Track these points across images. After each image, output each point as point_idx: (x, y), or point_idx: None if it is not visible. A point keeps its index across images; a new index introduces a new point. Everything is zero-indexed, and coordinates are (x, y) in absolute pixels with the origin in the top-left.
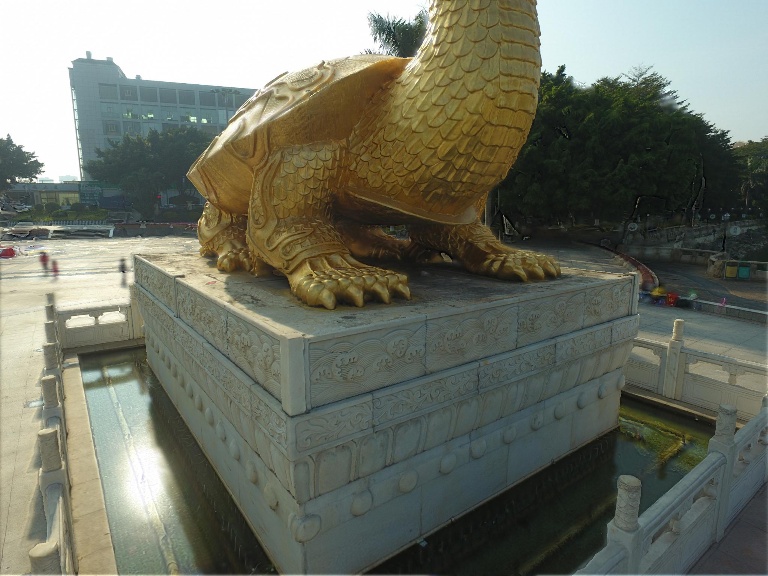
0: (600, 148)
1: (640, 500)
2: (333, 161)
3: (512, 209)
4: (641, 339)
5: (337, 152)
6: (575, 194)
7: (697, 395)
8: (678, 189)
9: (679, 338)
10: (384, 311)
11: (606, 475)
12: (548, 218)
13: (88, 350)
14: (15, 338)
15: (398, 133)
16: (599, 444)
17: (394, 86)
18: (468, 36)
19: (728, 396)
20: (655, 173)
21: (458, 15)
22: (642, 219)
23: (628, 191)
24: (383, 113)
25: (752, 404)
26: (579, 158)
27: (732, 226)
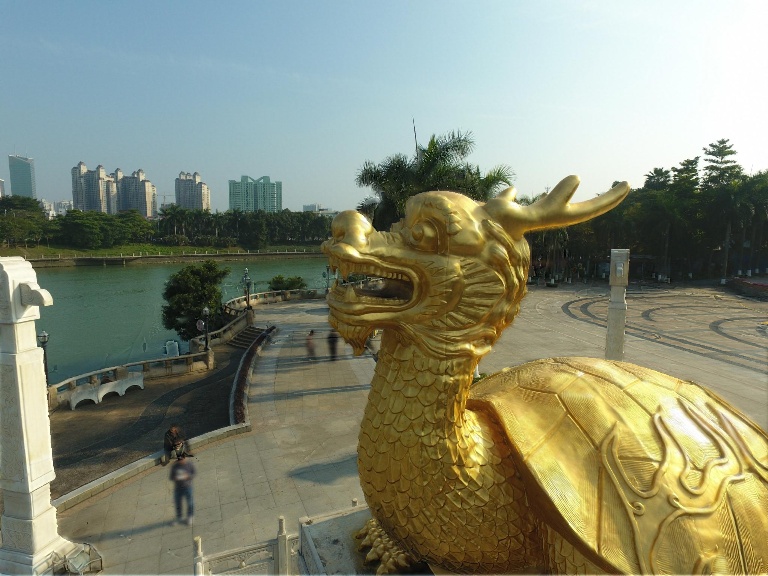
0: None
1: None
2: None
3: None
4: None
5: None
6: None
7: None
8: None
9: None
10: (344, 559)
11: None
12: None
13: None
14: None
15: None
16: None
17: None
18: None
19: None
20: None
21: None
22: None
23: None
24: None
25: None
26: None
27: None
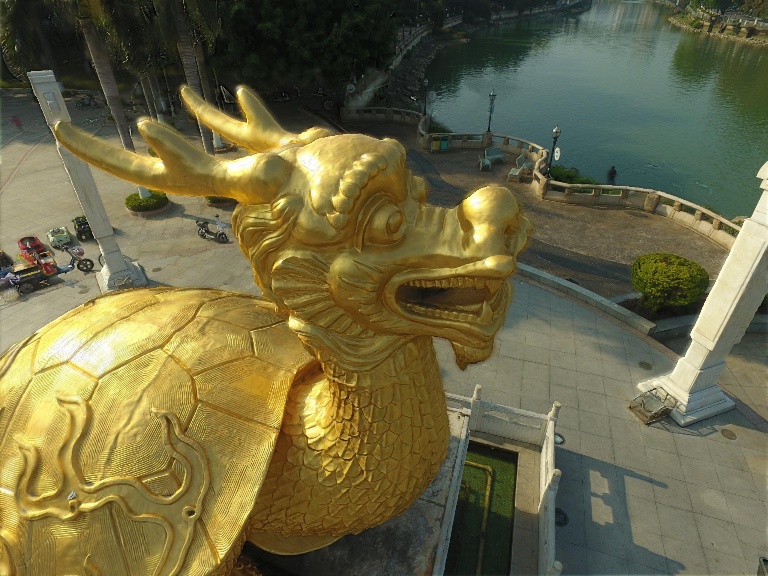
0: (311, 4)
1: (488, 561)
2: (241, 546)
3: (230, 79)
4: (452, 397)
5: (243, 537)
6: (296, 64)
7: (490, 428)
8: (385, 49)
9: (479, 398)
10: None
11: (463, 546)
12: (273, 91)
13: None
14: None
15: (326, 525)
16: (458, 533)
17: (301, 467)
18: (403, 466)
19: (509, 429)
20: (366, 35)
21: (390, 450)
22: (358, 80)
23: (346, 59)
24: (296, 497)
25: (522, 433)
26: (291, 15)
27: (430, 91)
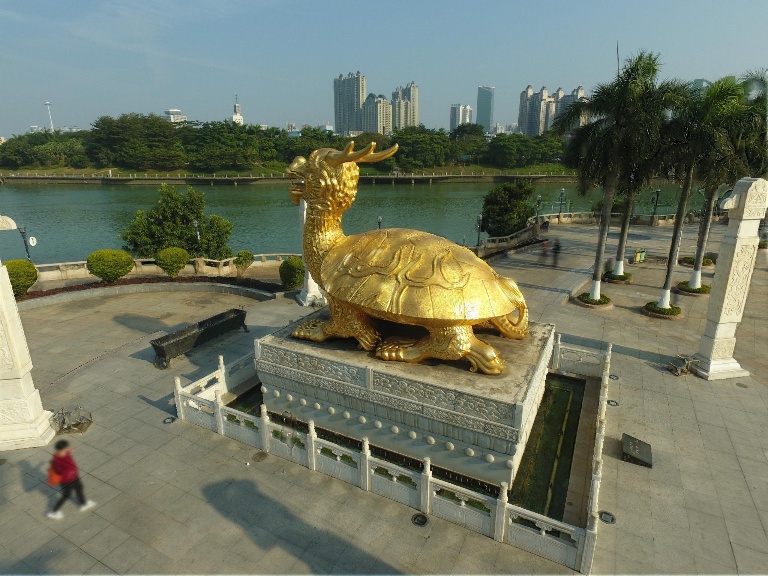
0: None
1: None
2: None
3: None
4: None
5: None
6: None
7: None
8: None
9: None
10: None
11: None
12: None
13: (588, 382)
14: (666, 380)
15: None
16: None
17: None
18: None
19: None
20: None
21: None
22: None
23: None
24: None
25: None
26: None
27: None
